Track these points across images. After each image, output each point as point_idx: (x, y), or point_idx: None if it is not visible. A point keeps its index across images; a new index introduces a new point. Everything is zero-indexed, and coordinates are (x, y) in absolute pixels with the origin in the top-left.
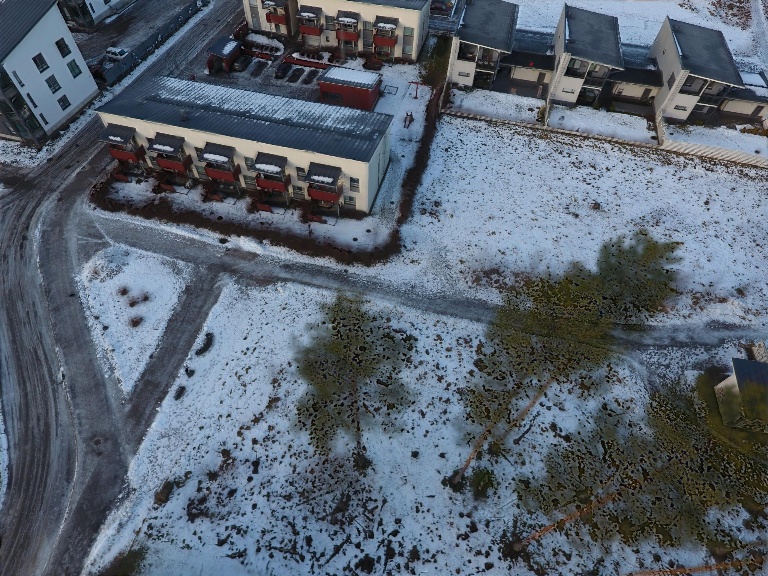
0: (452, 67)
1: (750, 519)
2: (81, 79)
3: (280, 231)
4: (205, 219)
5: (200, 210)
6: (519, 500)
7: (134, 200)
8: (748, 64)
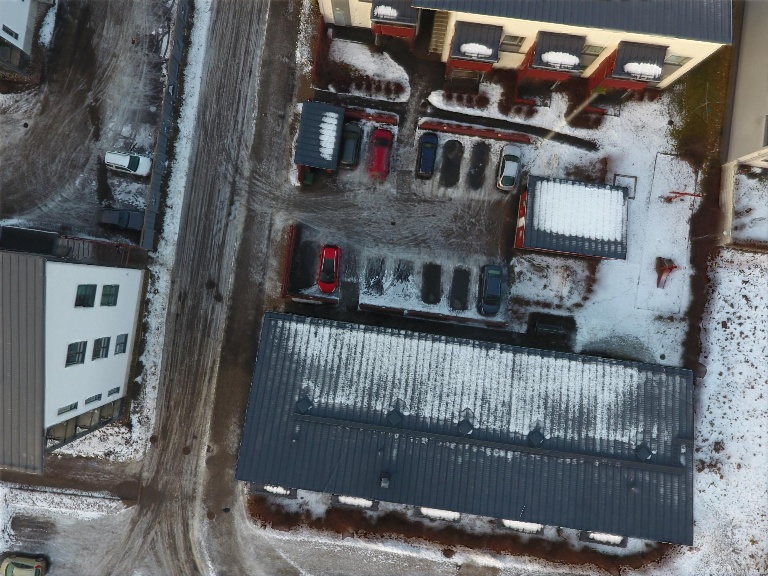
0: (758, 157)
1: None
2: (121, 292)
3: (519, 533)
4: (414, 523)
5: (402, 508)
6: None
7: (308, 502)
8: None
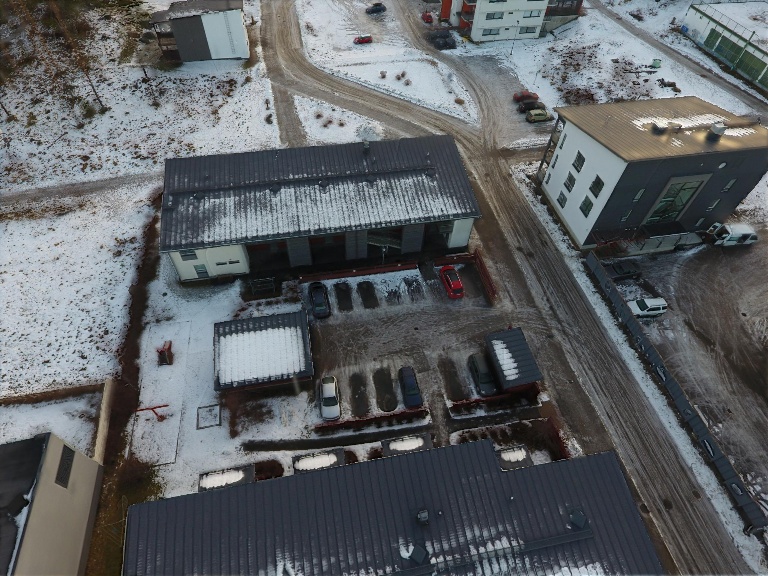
0: None
1: None
2: None
3: None
4: None
5: None
6: (69, 114)
7: None
8: None
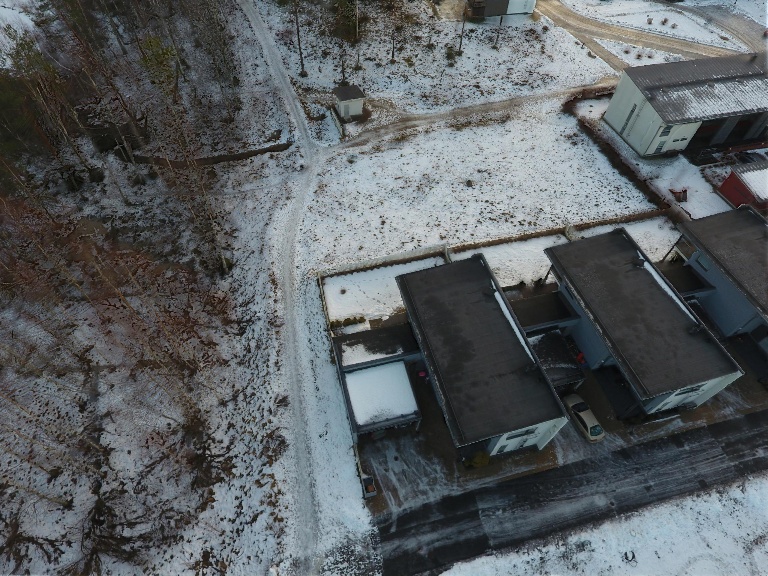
0: None
1: (345, 79)
2: None
3: None
4: None
5: None
6: None
7: None
8: (355, 575)
